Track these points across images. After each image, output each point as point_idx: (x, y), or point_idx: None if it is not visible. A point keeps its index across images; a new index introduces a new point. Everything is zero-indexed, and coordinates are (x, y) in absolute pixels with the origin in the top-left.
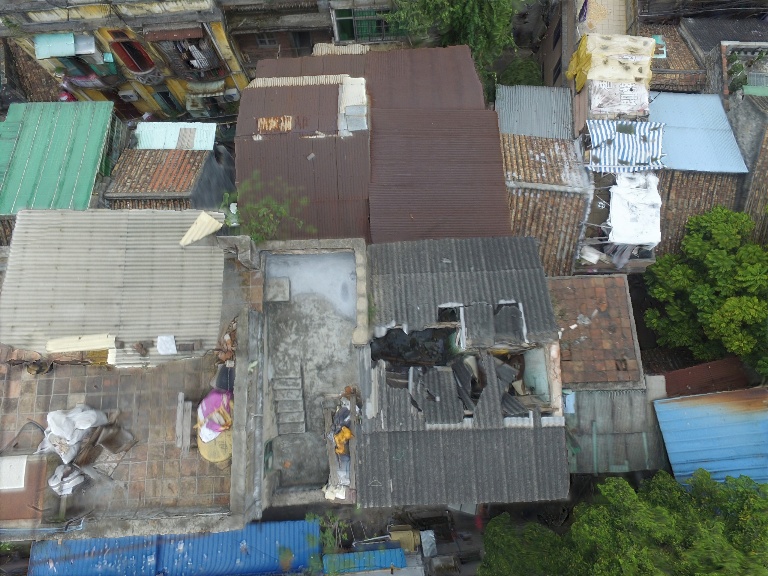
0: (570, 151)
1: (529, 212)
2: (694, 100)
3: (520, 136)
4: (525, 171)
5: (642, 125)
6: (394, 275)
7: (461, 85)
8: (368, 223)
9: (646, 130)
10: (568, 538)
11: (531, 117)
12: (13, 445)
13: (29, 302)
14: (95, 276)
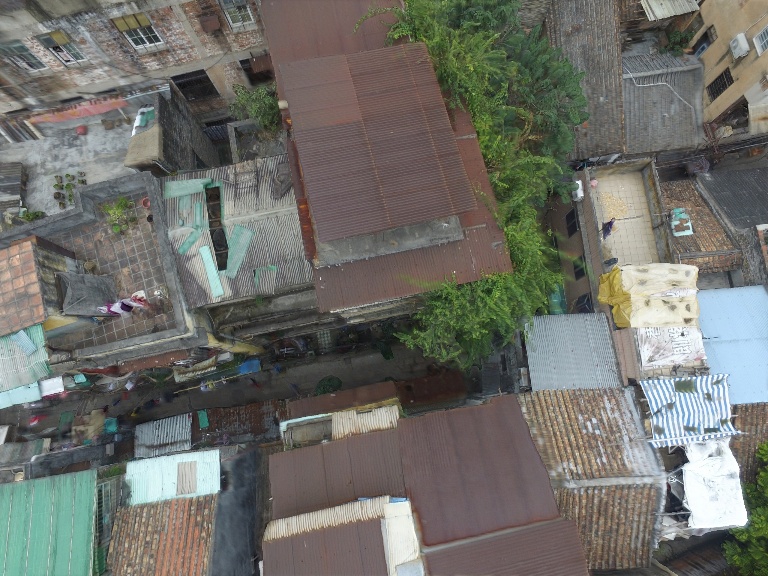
0: (623, 408)
1: (595, 508)
2: (738, 297)
3: (563, 393)
4: (582, 456)
5: (703, 380)
6: None
7: (523, 477)
8: None
9: (708, 385)
10: None
11: (569, 360)
12: None
13: None
14: None
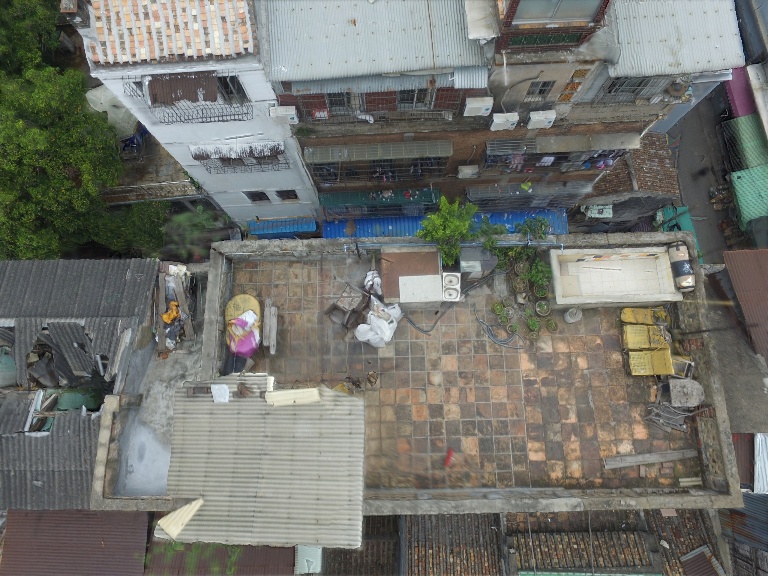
0: None
1: None
2: None
3: None
4: None
5: None
6: (91, 469)
7: None
8: (154, 538)
9: None
10: (83, 238)
11: None
12: (439, 313)
13: (340, 440)
14: (285, 467)
